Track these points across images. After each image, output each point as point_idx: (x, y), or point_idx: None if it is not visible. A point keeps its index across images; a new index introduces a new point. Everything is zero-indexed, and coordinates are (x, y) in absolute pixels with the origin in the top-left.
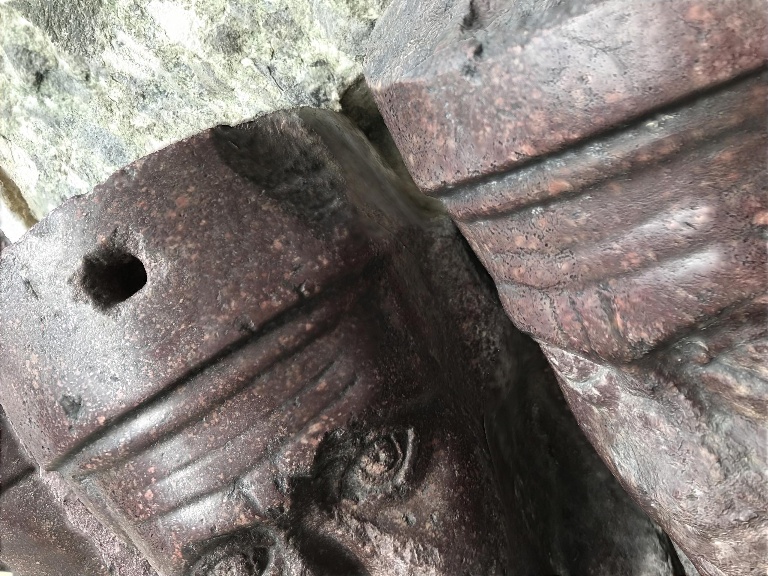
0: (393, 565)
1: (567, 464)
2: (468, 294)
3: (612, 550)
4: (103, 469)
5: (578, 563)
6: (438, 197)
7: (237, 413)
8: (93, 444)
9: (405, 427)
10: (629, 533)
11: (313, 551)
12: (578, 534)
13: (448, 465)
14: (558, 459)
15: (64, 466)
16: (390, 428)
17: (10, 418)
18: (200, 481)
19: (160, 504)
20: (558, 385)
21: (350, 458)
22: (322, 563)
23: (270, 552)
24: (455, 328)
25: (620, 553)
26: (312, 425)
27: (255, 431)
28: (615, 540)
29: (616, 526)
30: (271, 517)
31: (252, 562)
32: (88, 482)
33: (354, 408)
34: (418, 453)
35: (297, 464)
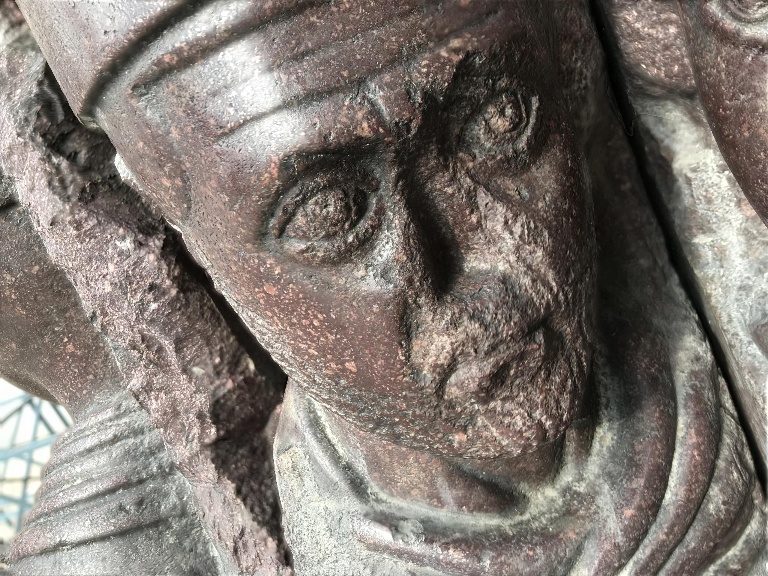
0: (497, 242)
1: (610, 249)
2: (573, 11)
3: (651, 328)
4: (185, 64)
5: (617, 337)
6: None
7: (372, 2)
8: (181, 22)
9: (531, 92)
10: (666, 318)
11: (416, 209)
12: (618, 312)
13: (563, 151)
14: (601, 243)
15: (122, 74)
16: (521, 82)
17: (49, 16)
18: (319, 76)
19: (262, 103)
20: (618, 162)
21: (478, 101)
22: (423, 226)
23: (370, 200)
24: (557, 43)
25: (659, 332)
26: (454, 38)
27: (390, 28)
28: (653, 321)
29: (654, 310)
30: (395, 135)
31: (351, 204)
32: (150, 99)
33: (497, 36)
34: (540, 124)
35: (434, 77)
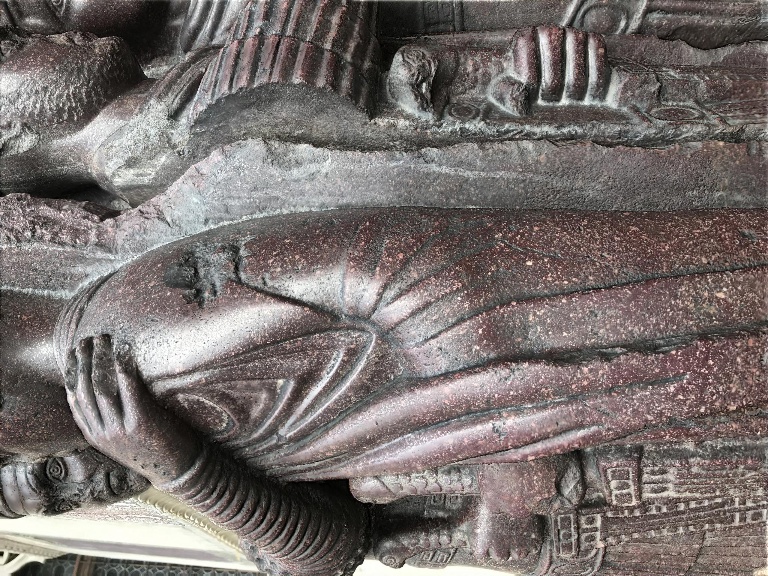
0: None
1: None
2: None
3: None
4: None
5: None
6: (5, 2)
7: None
8: None
9: None
10: None
11: None
12: None
13: None
14: None
15: None
16: None
17: None
18: None
19: None
20: None
21: None
22: None
23: None
24: None
25: None
26: None
27: None
28: None
29: None
30: None
31: None
32: None
33: None
34: None
35: None
